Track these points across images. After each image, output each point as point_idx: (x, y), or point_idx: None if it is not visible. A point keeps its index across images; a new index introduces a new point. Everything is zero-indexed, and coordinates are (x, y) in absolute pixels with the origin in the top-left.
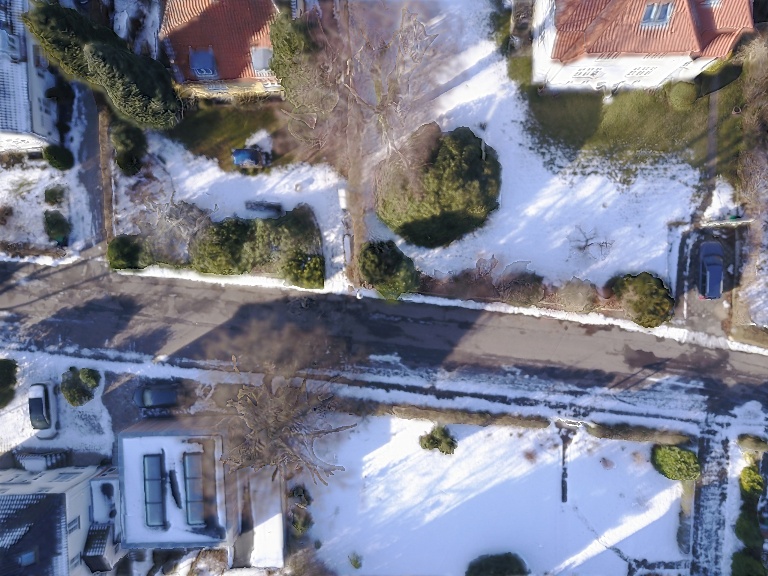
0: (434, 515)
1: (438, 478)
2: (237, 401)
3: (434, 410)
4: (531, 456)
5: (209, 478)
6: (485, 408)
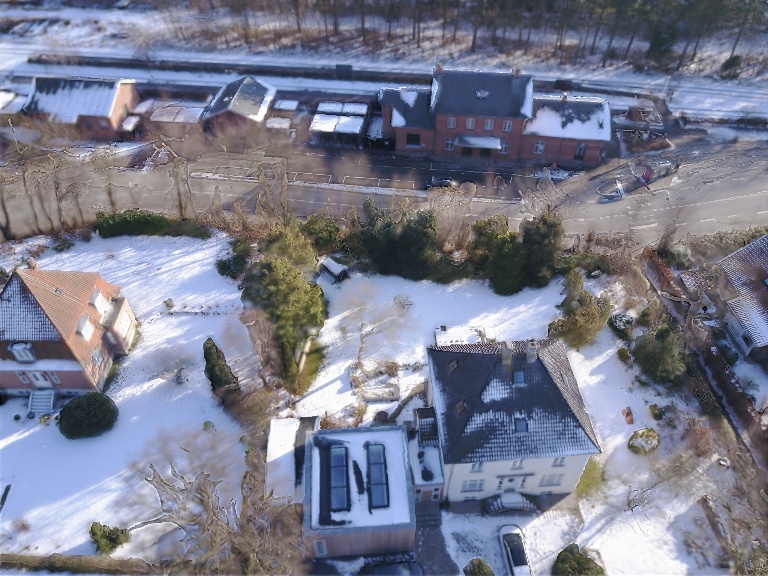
0: (135, 469)
1: (122, 502)
2: (315, 573)
3: (106, 570)
4: (24, 527)
5: (326, 488)
6: (54, 575)
